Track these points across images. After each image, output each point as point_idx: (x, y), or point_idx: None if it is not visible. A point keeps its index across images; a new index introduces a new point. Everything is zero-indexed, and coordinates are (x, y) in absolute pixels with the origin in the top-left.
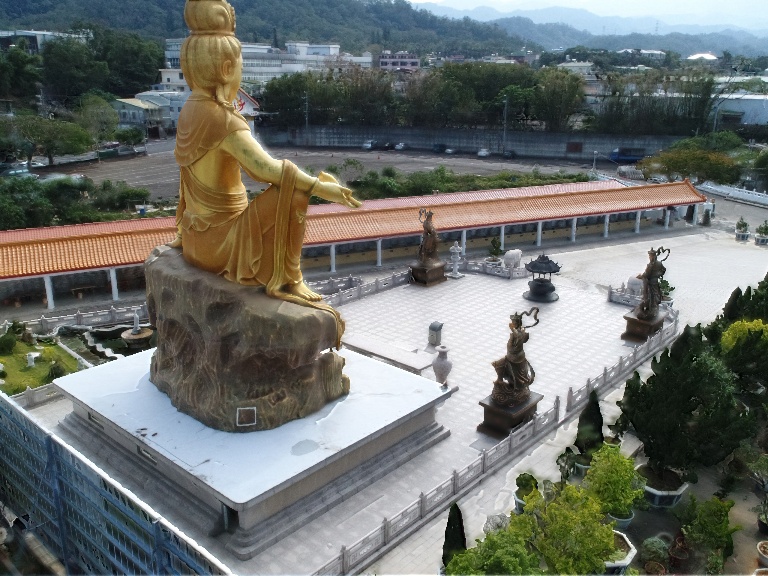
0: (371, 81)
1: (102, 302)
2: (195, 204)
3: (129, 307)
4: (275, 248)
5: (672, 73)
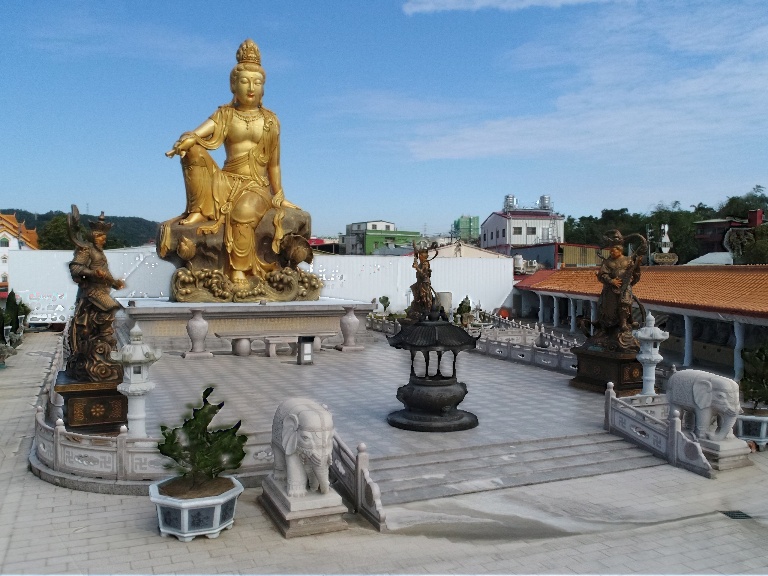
0: None
1: (566, 330)
2: None
3: None
4: None
5: None
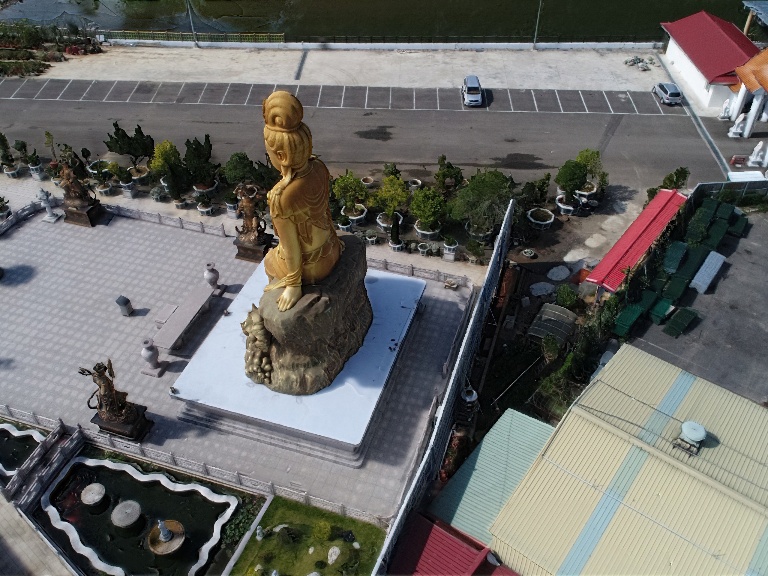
0: None
1: None
2: None
3: None
4: None
5: None
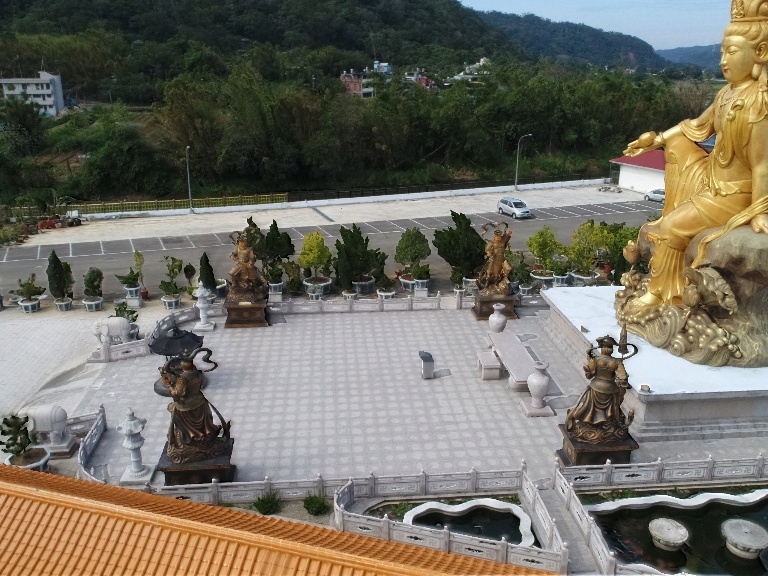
0: None
1: None
2: None
3: None
4: None
5: None
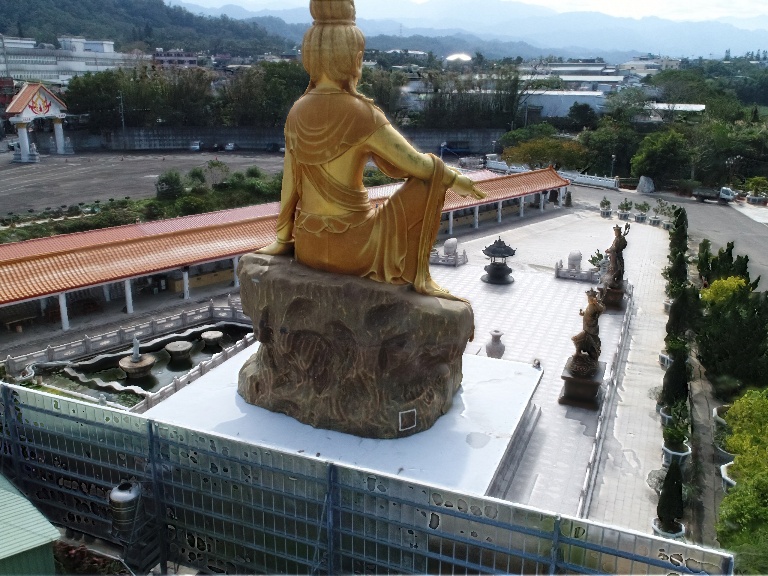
0: (190, 79)
1: (52, 333)
2: (329, 205)
3: (104, 334)
4: (420, 244)
5: (484, 71)
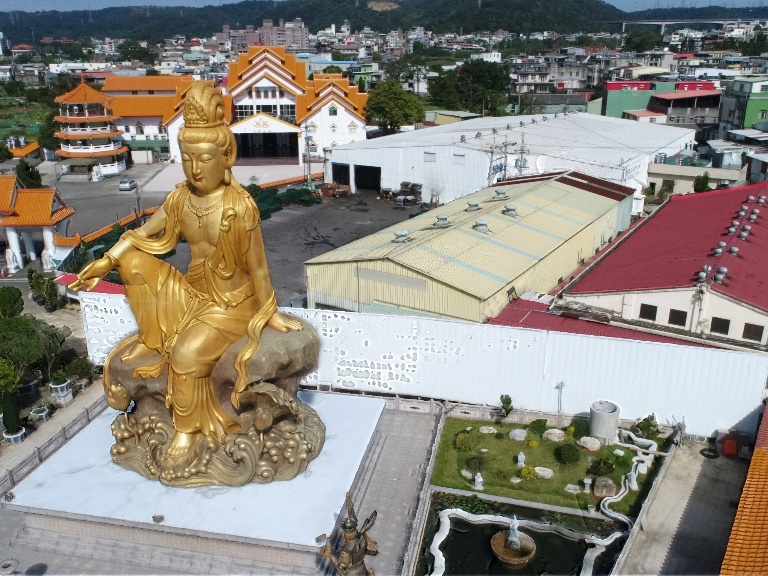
0: None
1: None
2: None
3: (612, 575)
4: None
5: None
